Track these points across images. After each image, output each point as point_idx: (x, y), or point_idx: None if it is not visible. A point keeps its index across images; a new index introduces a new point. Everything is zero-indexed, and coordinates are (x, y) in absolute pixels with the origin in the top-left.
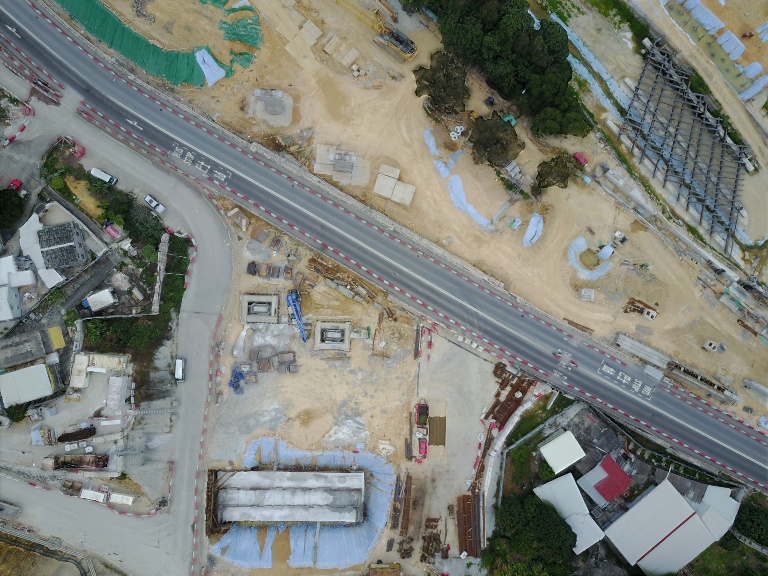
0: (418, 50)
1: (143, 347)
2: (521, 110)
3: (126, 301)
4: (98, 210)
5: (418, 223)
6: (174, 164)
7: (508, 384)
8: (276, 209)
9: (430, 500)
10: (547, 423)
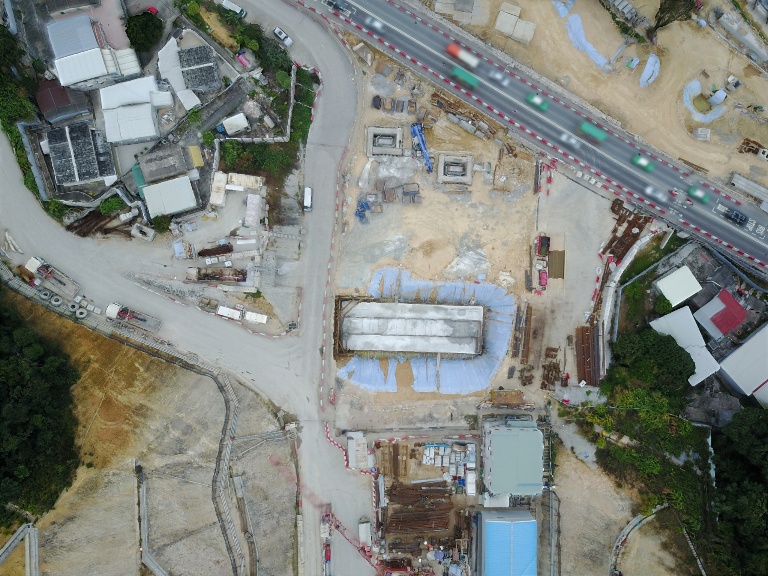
0: None
1: (276, 171)
2: None
3: (258, 128)
4: (230, 40)
5: (537, 62)
6: None
7: (625, 221)
8: (399, 45)
9: (549, 331)
10: (660, 263)
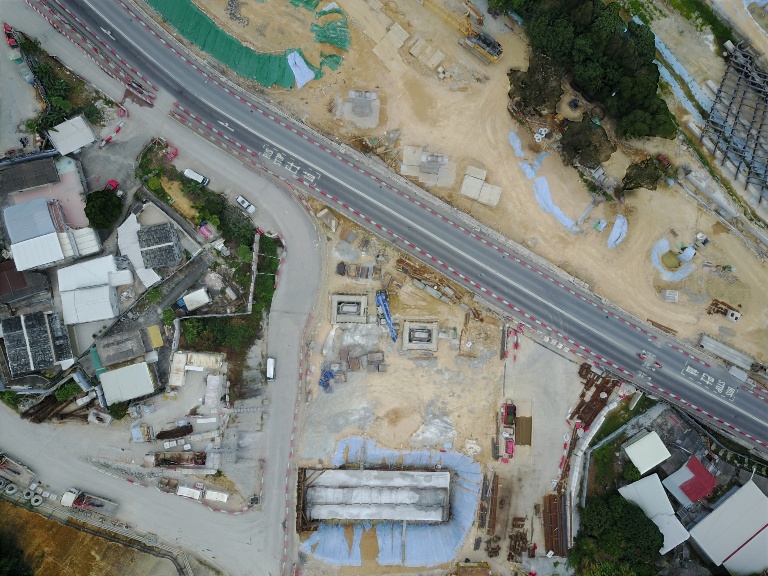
0: (502, 52)
1: (237, 346)
2: (604, 112)
3: (219, 300)
4: (192, 210)
5: (503, 224)
6: (265, 165)
7: (593, 385)
8: (364, 210)
9: (516, 499)
10: (630, 424)
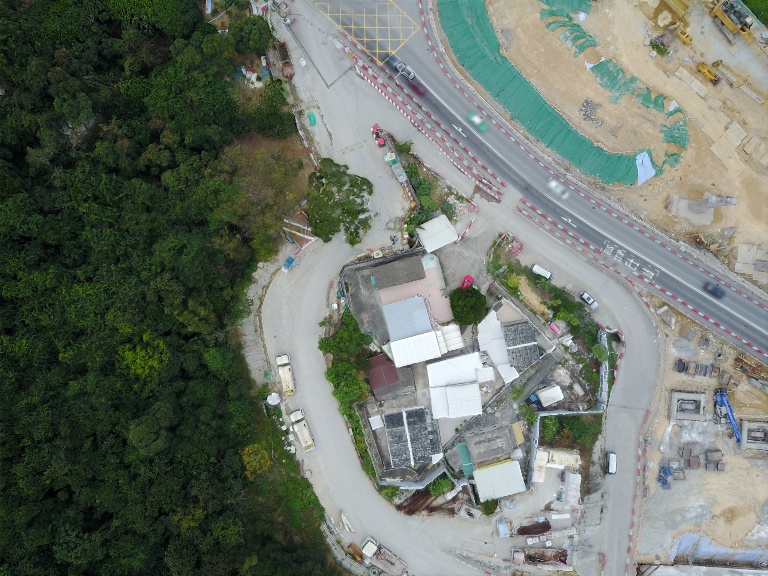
0: None
1: (588, 443)
2: None
3: (567, 396)
4: (541, 306)
5: None
6: (606, 261)
7: None
8: (701, 307)
9: None
10: None
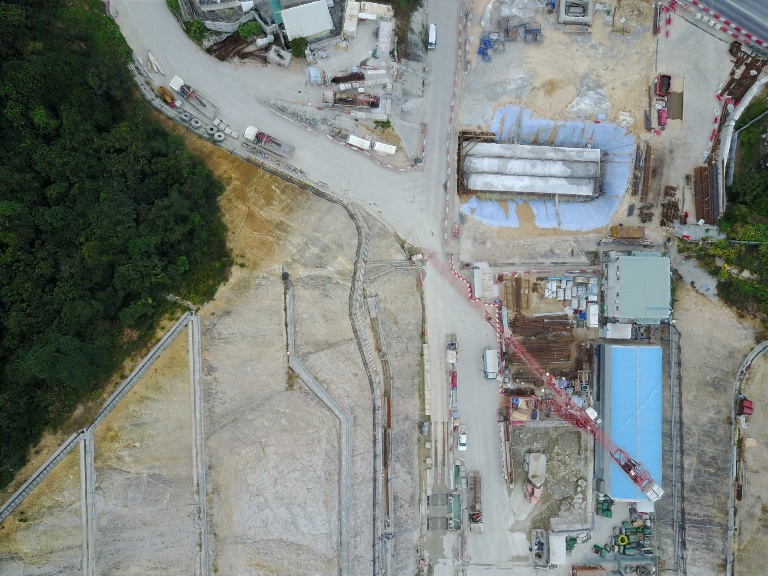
0: None
1: (404, 4)
2: None
3: None
4: None
5: None
6: None
7: (743, 63)
8: None
9: (668, 170)
10: None
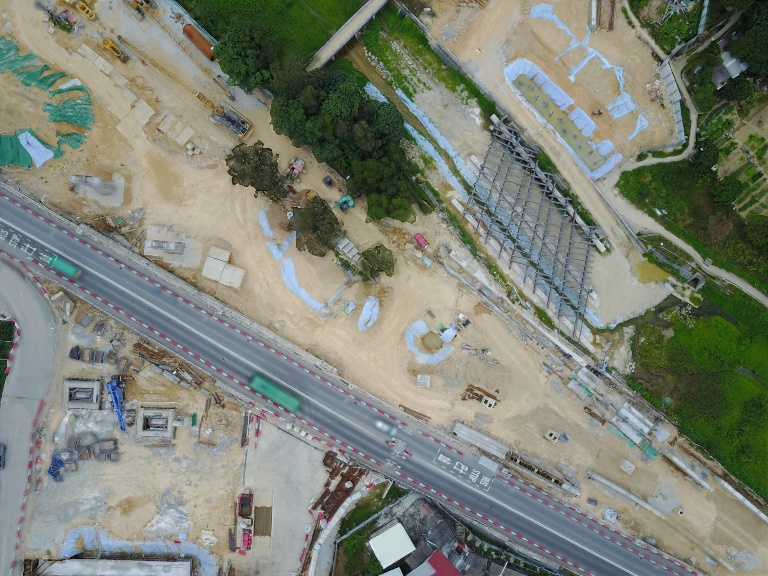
0: (255, 128)
1: None
2: None
3: None
4: None
5: (250, 306)
6: None
7: (339, 473)
8: (102, 292)
9: None
10: (383, 512)
